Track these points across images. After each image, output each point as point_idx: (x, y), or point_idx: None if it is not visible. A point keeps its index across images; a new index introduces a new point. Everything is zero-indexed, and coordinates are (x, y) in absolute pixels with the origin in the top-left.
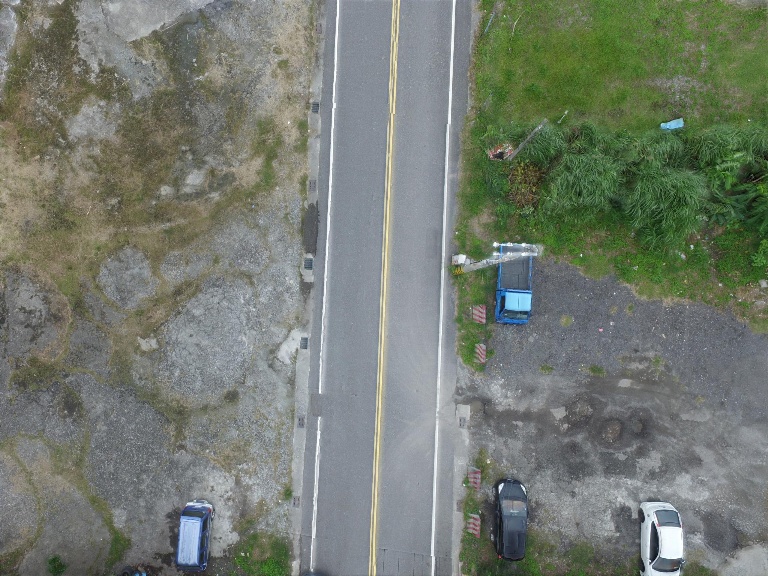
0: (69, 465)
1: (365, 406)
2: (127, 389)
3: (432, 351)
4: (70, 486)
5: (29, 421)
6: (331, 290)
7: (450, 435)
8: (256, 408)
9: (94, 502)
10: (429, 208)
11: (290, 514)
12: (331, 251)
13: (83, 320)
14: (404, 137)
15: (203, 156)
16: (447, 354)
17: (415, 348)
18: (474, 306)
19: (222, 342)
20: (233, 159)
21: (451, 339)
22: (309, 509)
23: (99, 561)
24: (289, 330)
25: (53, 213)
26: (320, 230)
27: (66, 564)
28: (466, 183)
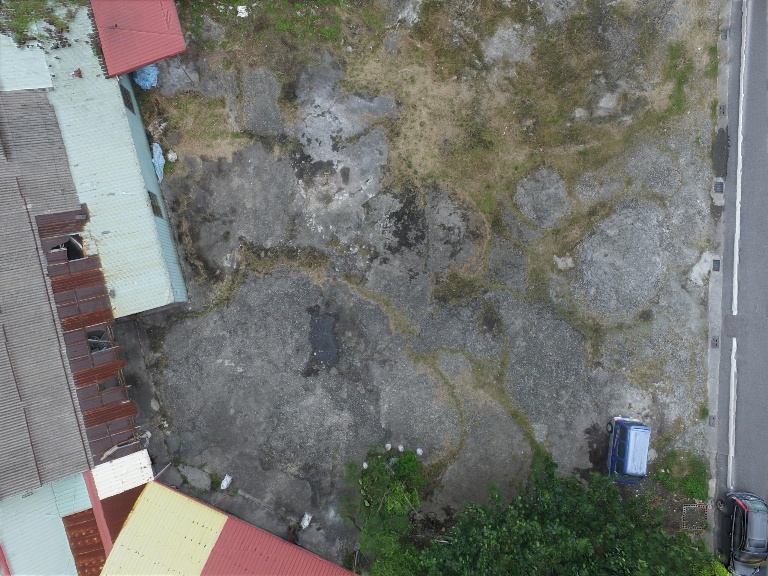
0: (490, 379)
1: None
2: (545, 306)
3: None
4: (492, 400)
5: (450, 335)
6: (743, 214)
7: None
8: (671, 328)
9: (517, 415)
10: None
11: (706, 433)
12: (743, 175)
13: (501, 238)
14: None
15: (616, 80)
16: None
17: None
18: None
19: (637, 262)
20: (646, 83)
21: None
22: (725, 428)
23: (522, 474)
24: (701, 252)
25: (470, 133)
26: (730, 155)
27: (488, 476)
28: None
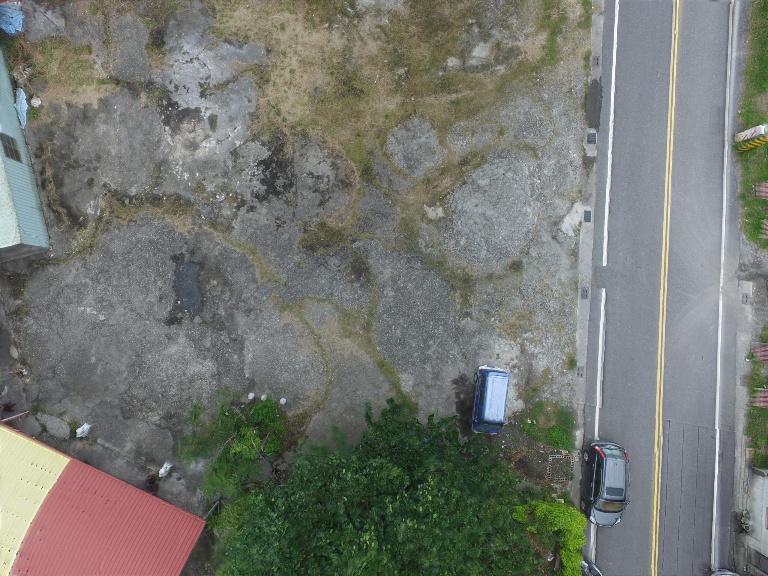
0: (357, 329)
1: (650, 279)
2: (413, 256)
3: (716, 227)
4: (358, 349)
5: (317, 284)
6: (615, 164)
7: (733, 310)
8: (541, 278)
9: (383, 365)
10: (712, 86)
11: (574, 384)
12: (615, 126)
13: (370, 187)
14: (688, 16)
15: (489, 29)
16: (730, 230)
17: (699, 223)
18: (758, 183)
19: (507, 212)
20: (519, 33)
21: (734, 216)
22: (593, 379)
23: None
24: (573, 203)
25: (341, 81)
26: (603, 105)
27: (353, 427)
28: (750, 62)
